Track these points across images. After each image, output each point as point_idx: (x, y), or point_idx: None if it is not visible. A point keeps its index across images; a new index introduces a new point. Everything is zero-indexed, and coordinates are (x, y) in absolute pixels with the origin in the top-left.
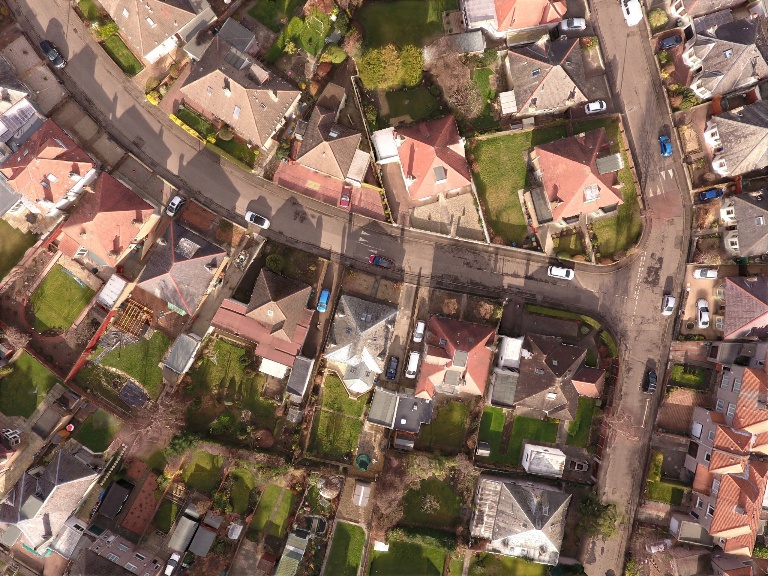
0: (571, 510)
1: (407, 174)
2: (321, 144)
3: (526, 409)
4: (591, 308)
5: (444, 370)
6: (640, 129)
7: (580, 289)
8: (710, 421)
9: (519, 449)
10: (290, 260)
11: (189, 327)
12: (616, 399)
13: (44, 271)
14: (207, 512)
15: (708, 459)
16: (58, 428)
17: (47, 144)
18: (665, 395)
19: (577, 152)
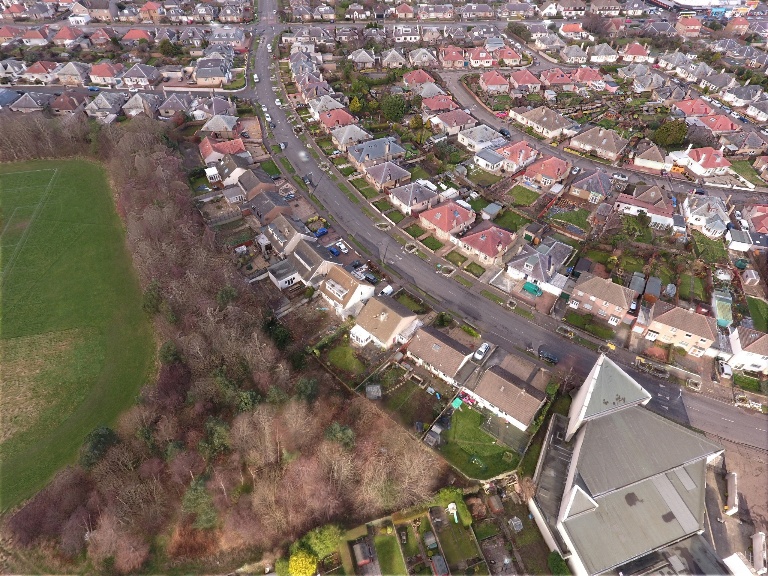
0: None
1: (698, 160)
2: (652, 147)
3: None
4: None
5: None
6: None
7: None
8: None
9: None
10: None
11: None
12: None
13: (511, 187)
14: None
15: None
16: None
17: None
18: None
19: None
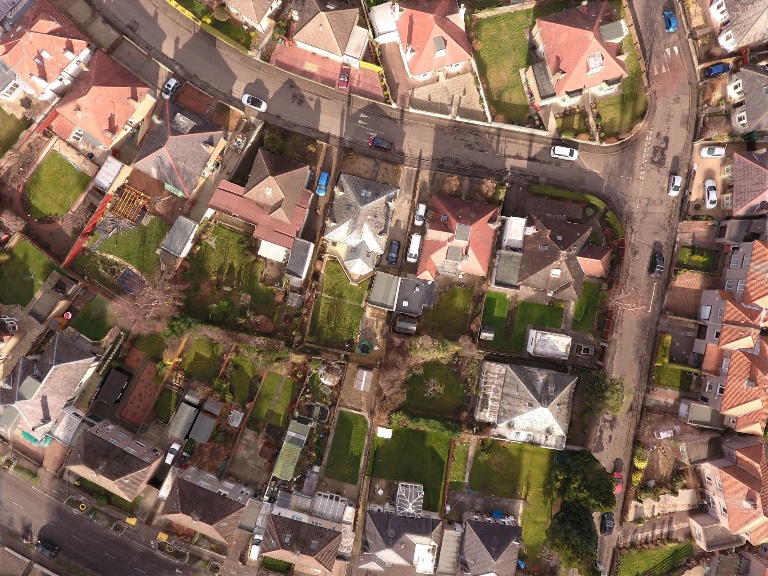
0: (578, 397)
1: (406, 48)
2: (318, 15)
3: (530, 294)
4: (596, 190)
5: (446, 246)
6: (644, 5)
7: (584, 170)
8: (719, 299)
9: (524, 335)
10: (288, 144)
11: (187, 212)
12: (622, 278)
13: (39, 157)
14: (207, 398)
15: (718, 336)
16: (55, 313)
17: (40, 17)
18: (673, 277)
19: (579, 20)
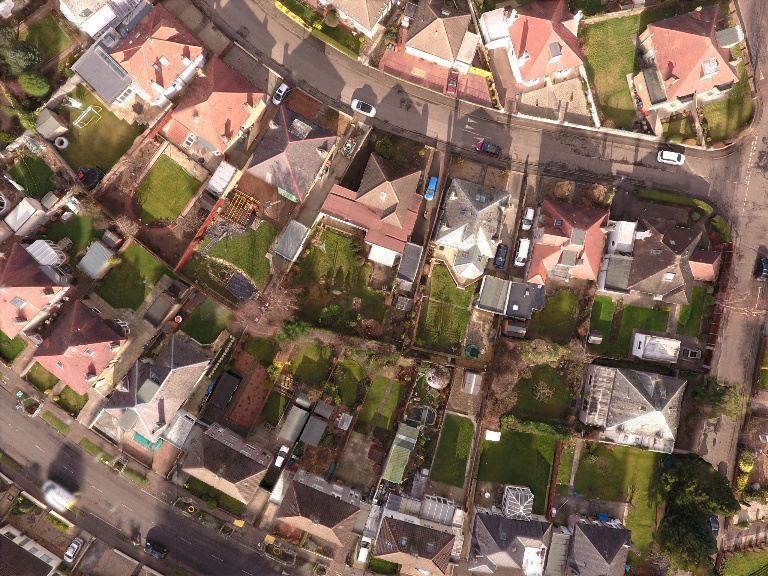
0: None
1: (519, 54)
2: (435, 21)
3: (636, 298)
4: (701, 194)
5: (560, 250)
6: (750, 11)
7: (690, 175)
8: None
9: (629, 339)
10: (396, 148)
11: (296, 217)
12: (732, 282)
13: (150, 162)
14: (318, 401)
15: None
16: (168, 317)
17: (161, 24)
18: None
19: (694, 26)
